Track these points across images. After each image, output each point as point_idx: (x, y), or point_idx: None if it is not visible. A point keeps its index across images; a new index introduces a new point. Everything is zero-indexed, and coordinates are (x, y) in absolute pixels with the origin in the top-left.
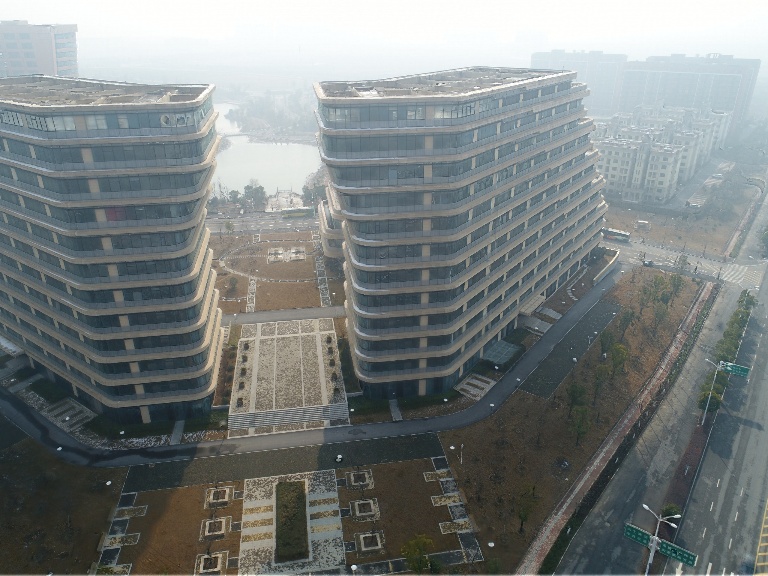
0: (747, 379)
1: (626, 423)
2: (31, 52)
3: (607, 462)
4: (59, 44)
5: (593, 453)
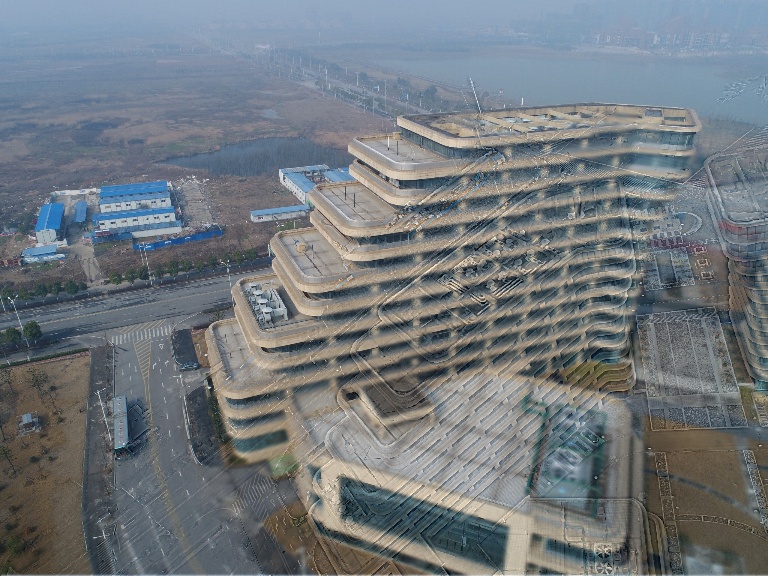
0: None
1: None
2: None
3: None
4: None
5: None
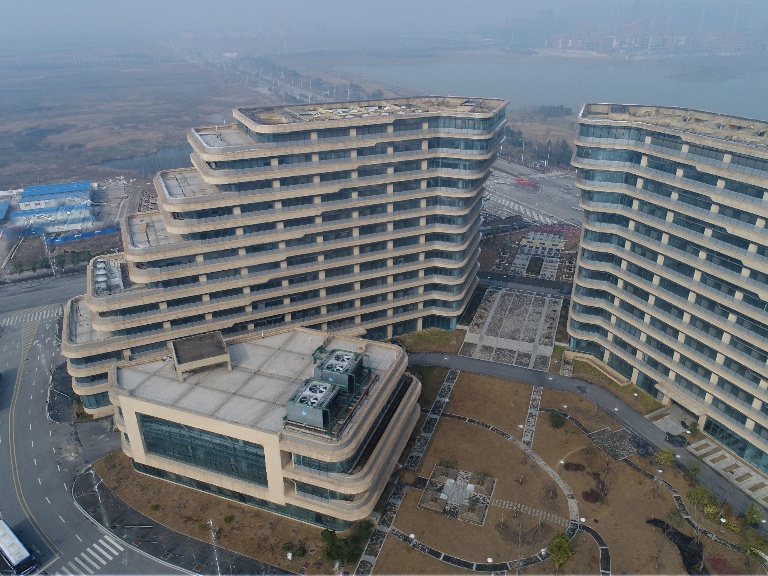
0: None
1: None
2: None
3: None
4: None
5: None
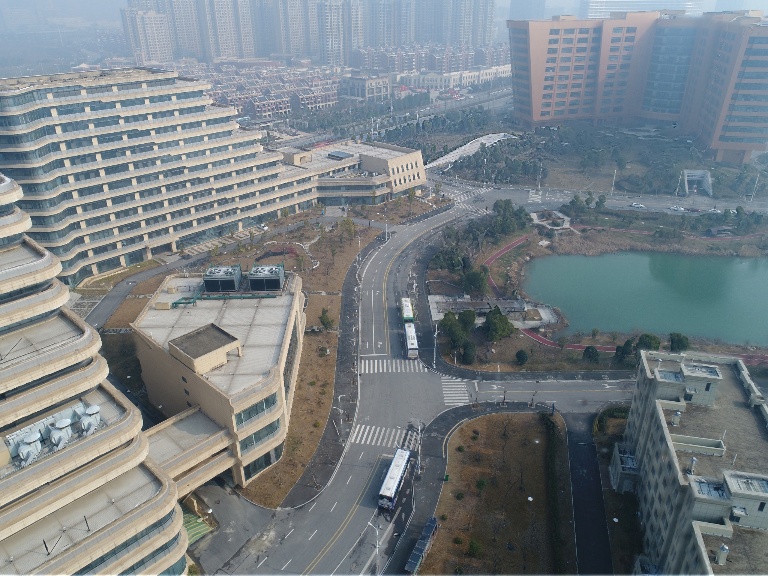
0: None
1: None
2: (729, 56)
3: None
4: (759, 50)
5: None
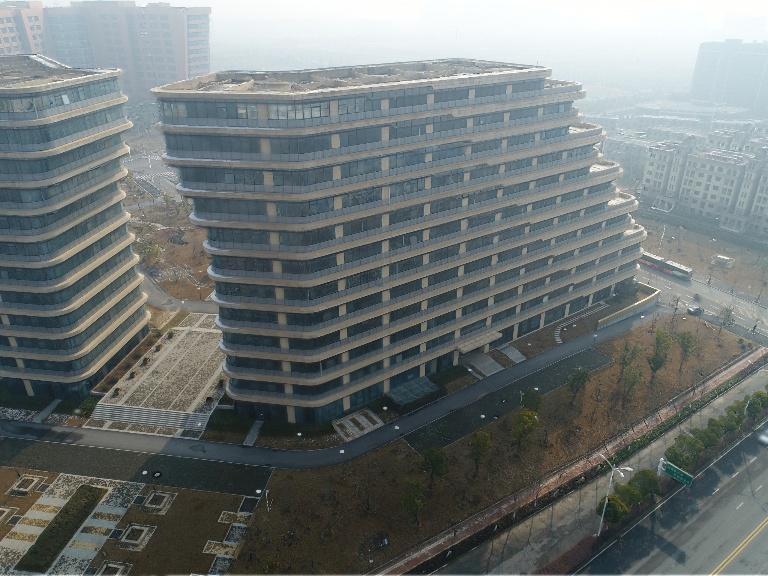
0: (716, 488)
1: (502, 509)
2: (168, 32)
3: (439, 552)
4: (192, 25)
5: (429, 537)
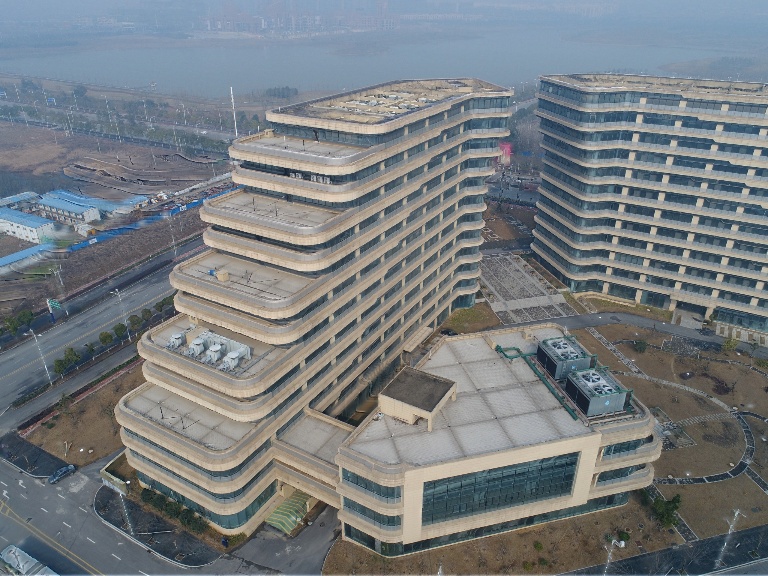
0: (171, 306)
1: None
2: None
3: None
4: None
5: None
